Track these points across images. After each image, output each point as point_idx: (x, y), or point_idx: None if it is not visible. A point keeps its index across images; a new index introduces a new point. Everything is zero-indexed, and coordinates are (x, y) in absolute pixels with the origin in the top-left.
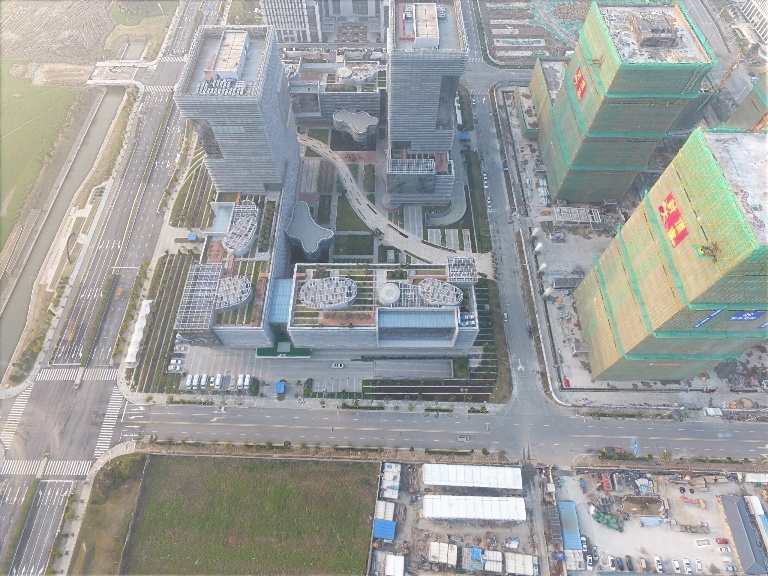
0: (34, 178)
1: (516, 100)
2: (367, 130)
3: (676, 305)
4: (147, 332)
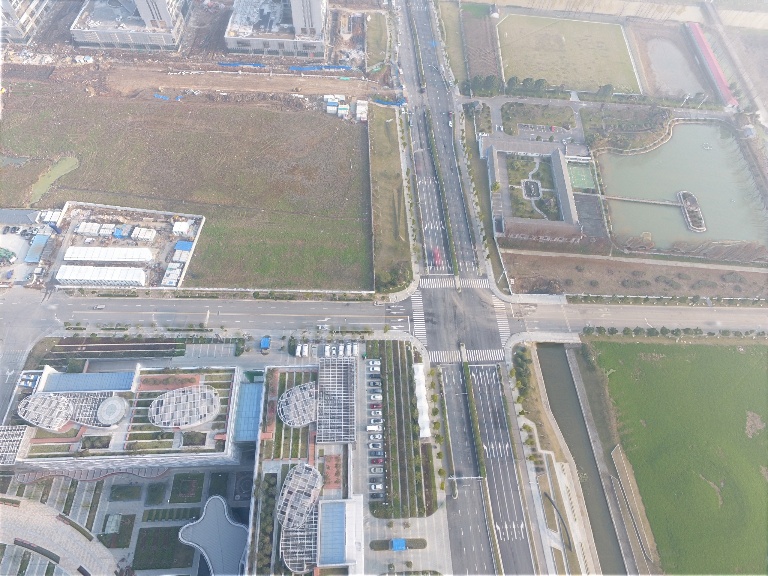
0: None
1: None
2: None
3: None
4: None
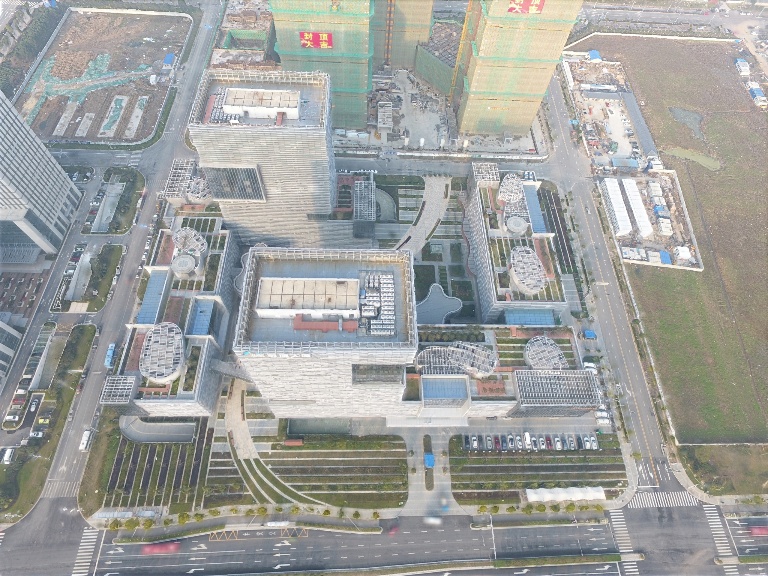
0: None
1: None
2: None
3: (566, 32)
4: None
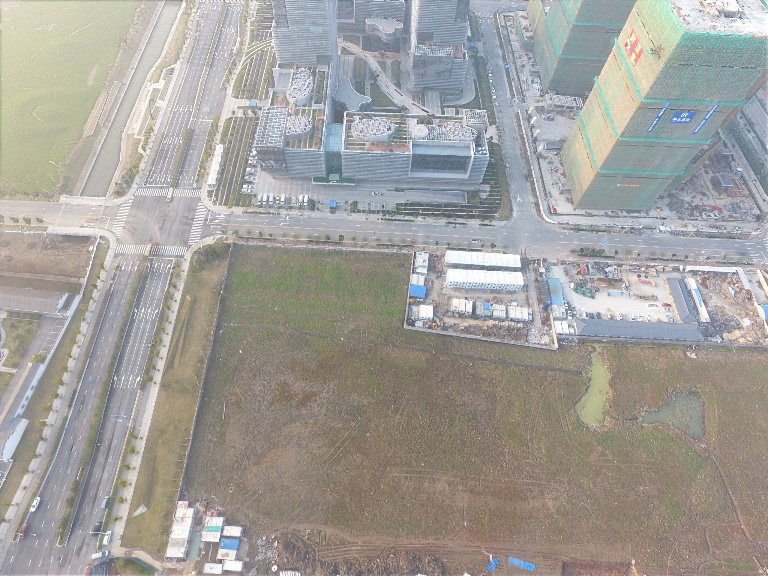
0: (113, 59)
1: (515, 21)
2: (394, 32)
3: (634, 106)
4: (222, 166)
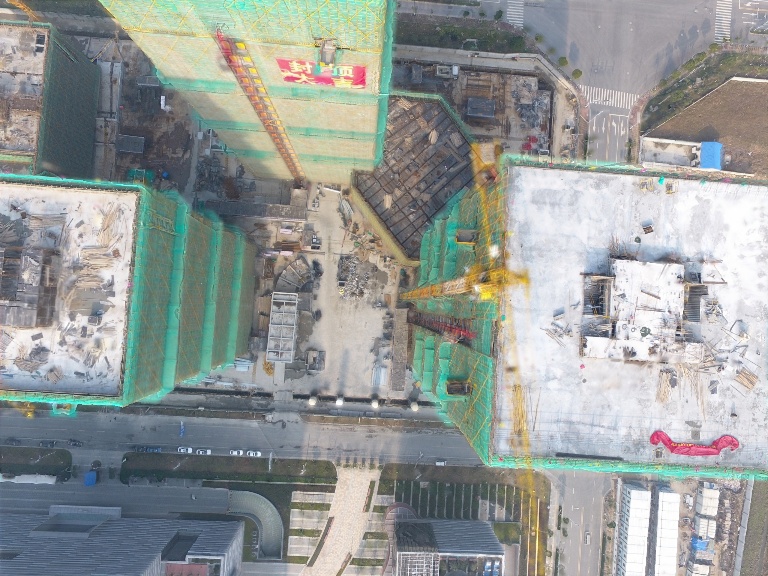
0: None
1: None
2: None
3: None
4: None
